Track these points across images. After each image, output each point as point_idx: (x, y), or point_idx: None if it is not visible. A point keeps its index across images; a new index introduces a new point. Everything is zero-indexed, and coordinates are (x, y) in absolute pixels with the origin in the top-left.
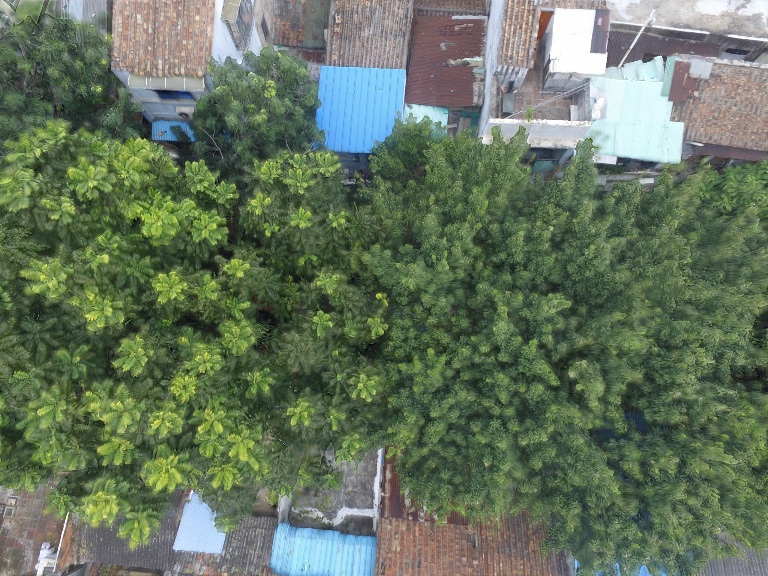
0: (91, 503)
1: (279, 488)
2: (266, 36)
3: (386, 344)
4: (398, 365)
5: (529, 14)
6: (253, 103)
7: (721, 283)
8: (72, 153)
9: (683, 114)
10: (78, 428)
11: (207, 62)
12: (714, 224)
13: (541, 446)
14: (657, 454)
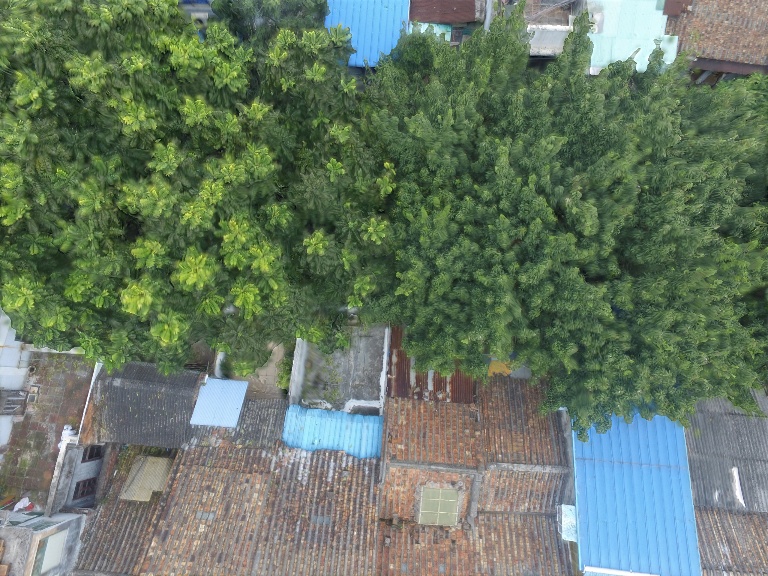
0: (127, 295)
1: (294, 331)
2: None
3: (394, 208)
4: (406, 214)
5: None
6: None
7: None
8: None
9: (677, 28)
10: (113, 233)
11: None
12: (704, 100)
13: (540, 288)
14: (648, 287)
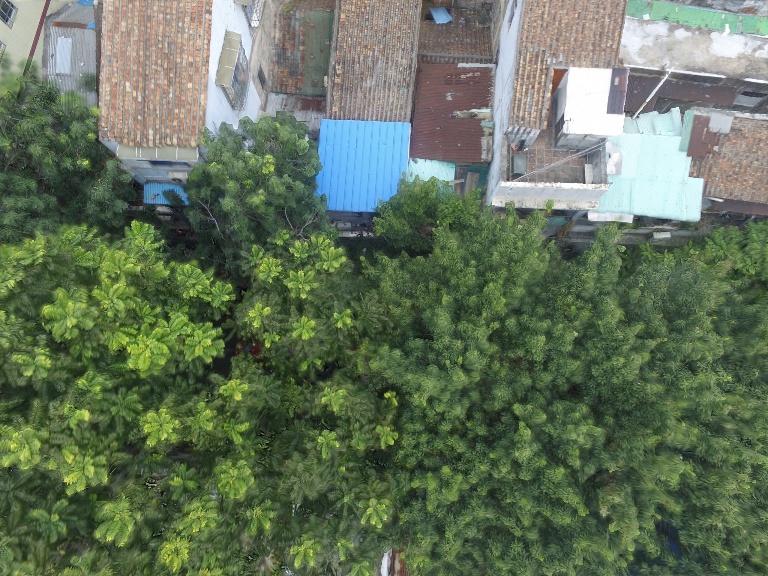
0: None
1: None
2: (263, 85)
3: (396, 448)
4: None
5: (542, 73)
6: (250, 179)
7: (756, 380)
8: (51, 271)
9: (702, 169)
10: None
11: (201, 131)
12: (746, 312)
13: None
14: None
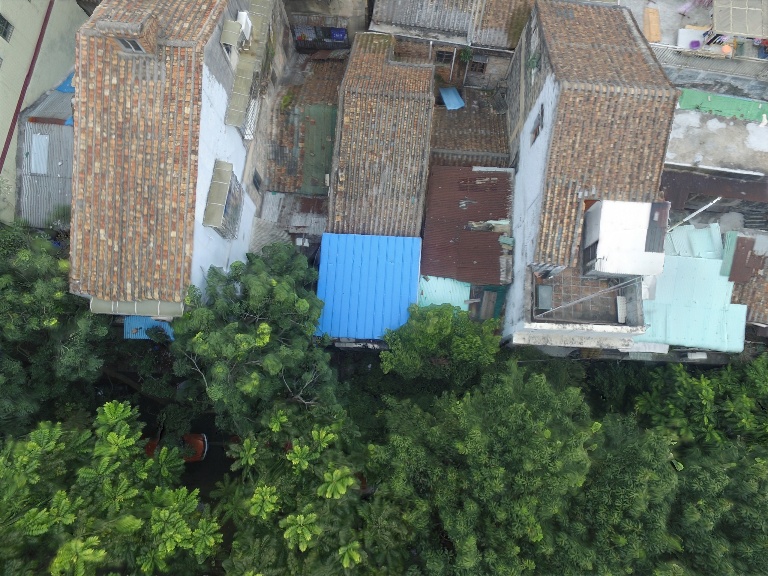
0: None
1: None
2: (259, 186)
3: None
4: None
5: (572, 207)
6: None
7: None
8: None
9: (745, 294)
10: None
11: (186, 285)
12: None
13: None
14: None
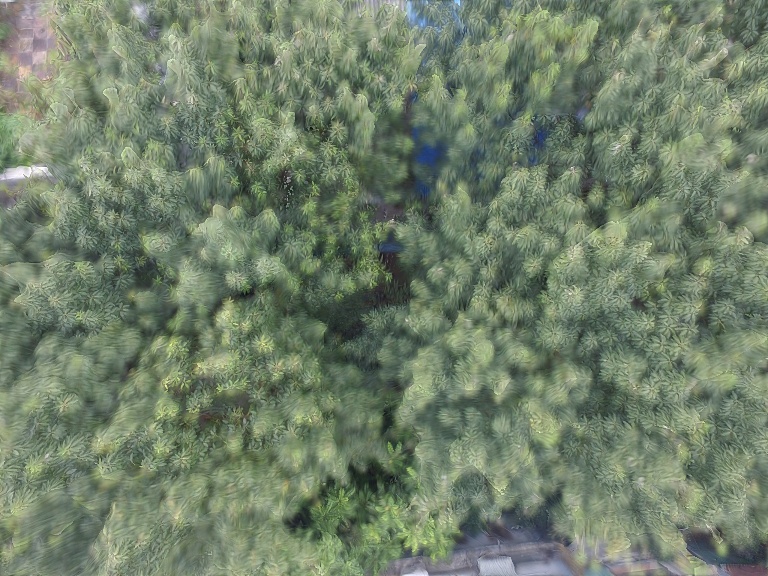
0: None
1: None
2: None
3: None
4: None
5: None
6: None
7: (527, 325)
8: None
9: None
10: None
11: None
12: None
13: None
14: None
